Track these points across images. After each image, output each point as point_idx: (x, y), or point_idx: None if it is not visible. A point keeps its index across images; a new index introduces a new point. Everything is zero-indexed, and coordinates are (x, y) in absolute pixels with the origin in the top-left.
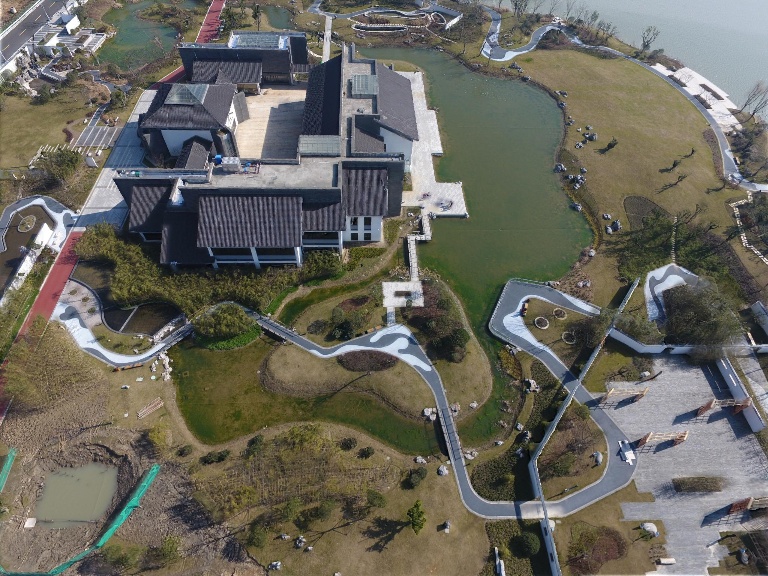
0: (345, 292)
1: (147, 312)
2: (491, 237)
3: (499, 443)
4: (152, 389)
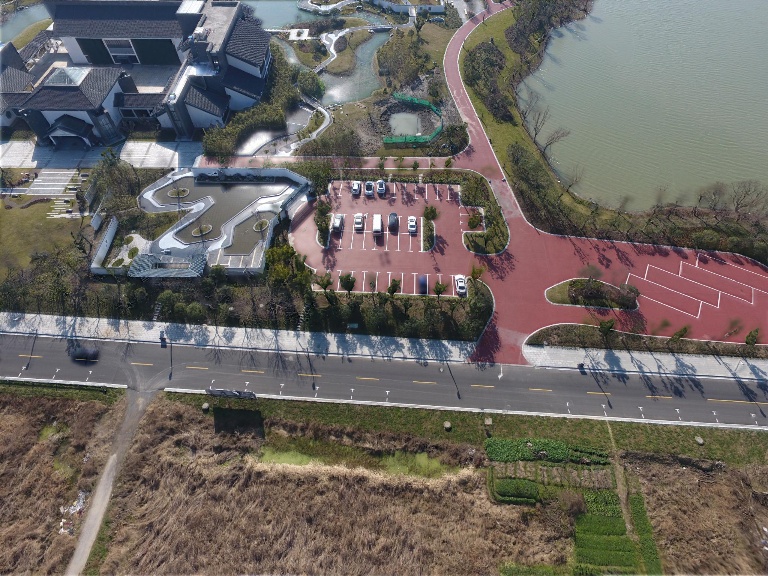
0: (292, 53)
1: (292, 118)
2: (262, 10)
3: (386, 17)
4: (349, 107)
